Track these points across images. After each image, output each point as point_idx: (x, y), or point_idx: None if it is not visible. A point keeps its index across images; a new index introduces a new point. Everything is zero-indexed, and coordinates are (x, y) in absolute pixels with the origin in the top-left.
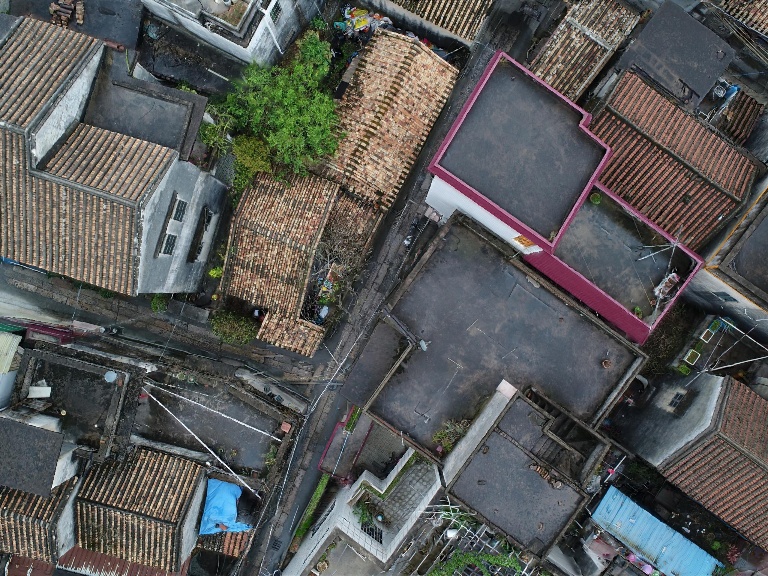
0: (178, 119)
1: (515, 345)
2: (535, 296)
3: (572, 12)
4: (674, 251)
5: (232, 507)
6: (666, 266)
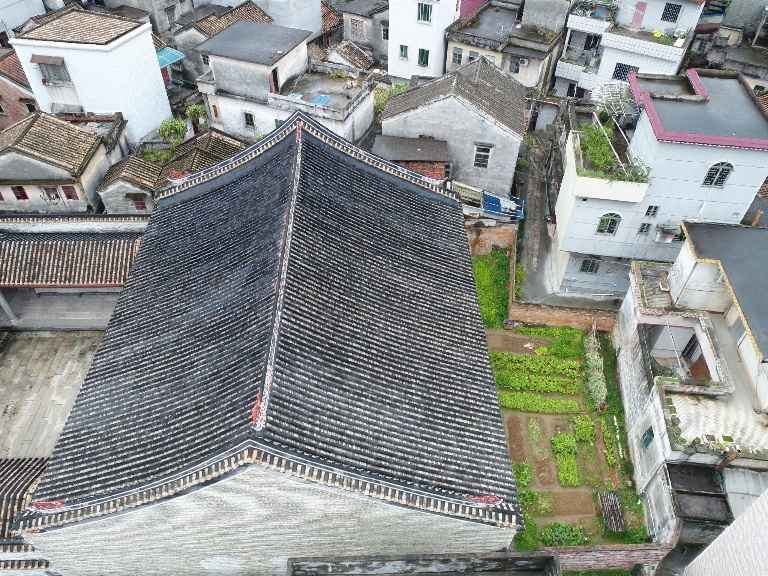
0: (426, 81)
1: None
2: None
3: (333, 49)
4: None
5: None
6: None
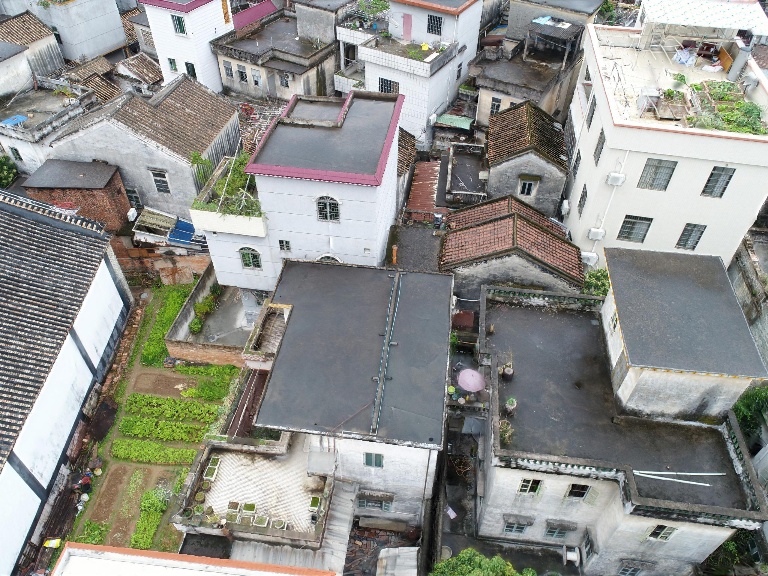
0: None
1: (278, 37)
2: (255, 34)
3: (119, 62)
4: (238, 7)
5: None
6: (245, 8)
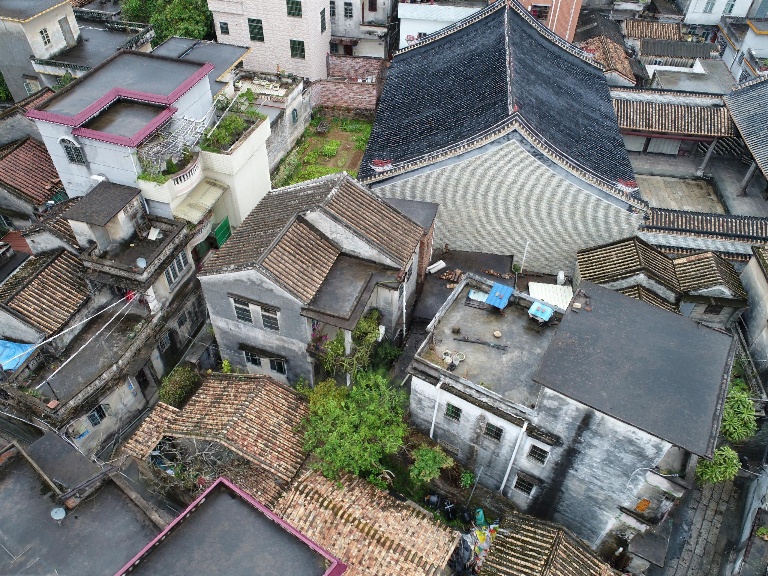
0: (337, 310)
1: None
2: None
3: None
4: None
5: (8, 367)
6: None
